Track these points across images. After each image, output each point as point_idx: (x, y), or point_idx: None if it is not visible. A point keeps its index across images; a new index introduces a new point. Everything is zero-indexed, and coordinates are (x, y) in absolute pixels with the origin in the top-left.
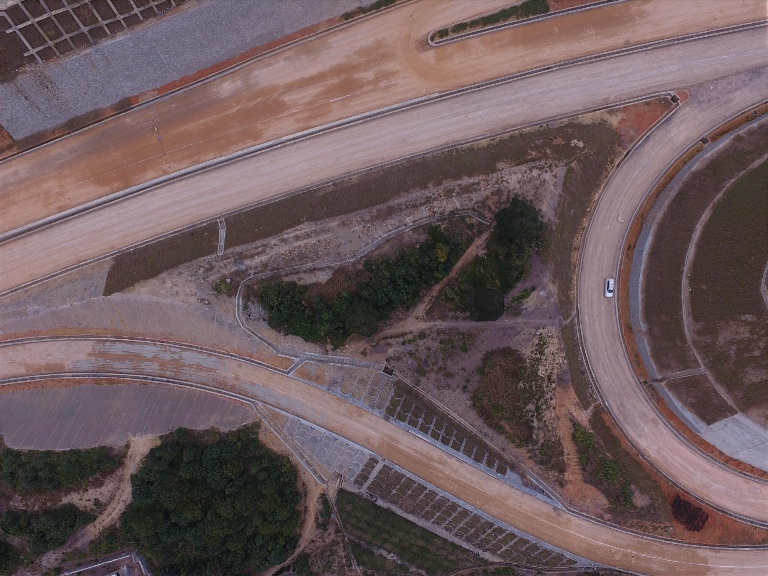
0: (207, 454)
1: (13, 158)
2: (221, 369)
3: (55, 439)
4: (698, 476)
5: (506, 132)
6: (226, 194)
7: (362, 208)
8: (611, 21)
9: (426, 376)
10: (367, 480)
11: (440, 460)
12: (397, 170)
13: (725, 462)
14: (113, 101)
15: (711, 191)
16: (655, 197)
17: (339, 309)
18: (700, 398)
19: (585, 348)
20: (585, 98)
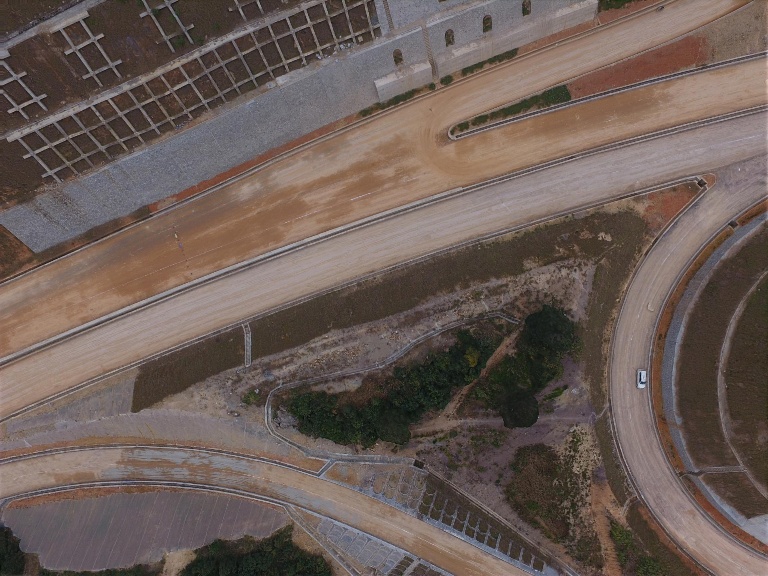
0: (243, 567)
1: (34, 271)
2: (251, 473)
3: (90, 558)
4: (738, 567)
5: (531, 224)
6: (249, 298)
7: (389, 314)
8: (634, 106)
9: (458, 470)
10: (402, 575)
11: (476, 558)
12: (422, 268)
13: (765, 552)
14: (132, 210)
15: (744, 283)
16: (685, 284)
17: (370, 417)
18: (739, 493)
19: (619, 441)
20: (610, 186)
